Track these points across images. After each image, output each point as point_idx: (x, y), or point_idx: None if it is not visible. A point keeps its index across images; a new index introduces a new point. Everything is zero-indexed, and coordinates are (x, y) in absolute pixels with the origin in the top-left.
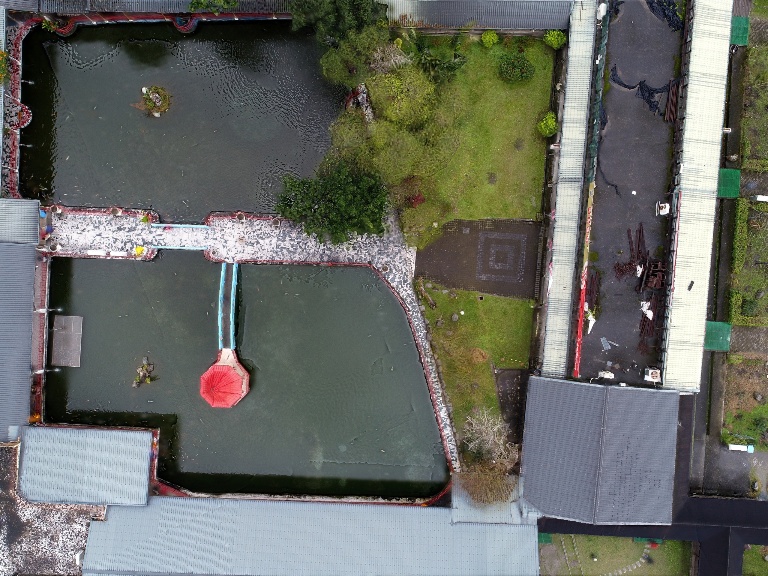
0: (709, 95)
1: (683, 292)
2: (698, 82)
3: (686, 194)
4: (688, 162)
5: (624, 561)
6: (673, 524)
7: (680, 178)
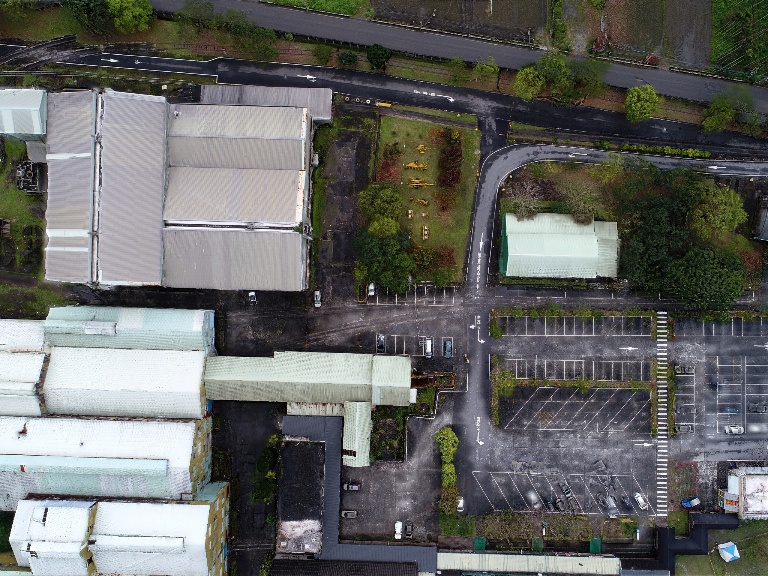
0: (511, 562)
1: (584, 568)
2: (507, 567)
3: (548, 569)
4: (536, 569)
5: (683, 573)
6: (669, 570)
7: (542, 572)
